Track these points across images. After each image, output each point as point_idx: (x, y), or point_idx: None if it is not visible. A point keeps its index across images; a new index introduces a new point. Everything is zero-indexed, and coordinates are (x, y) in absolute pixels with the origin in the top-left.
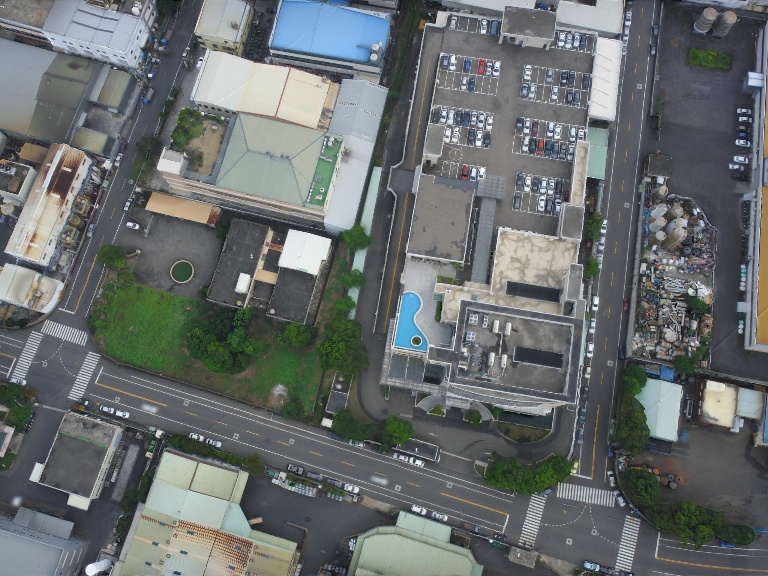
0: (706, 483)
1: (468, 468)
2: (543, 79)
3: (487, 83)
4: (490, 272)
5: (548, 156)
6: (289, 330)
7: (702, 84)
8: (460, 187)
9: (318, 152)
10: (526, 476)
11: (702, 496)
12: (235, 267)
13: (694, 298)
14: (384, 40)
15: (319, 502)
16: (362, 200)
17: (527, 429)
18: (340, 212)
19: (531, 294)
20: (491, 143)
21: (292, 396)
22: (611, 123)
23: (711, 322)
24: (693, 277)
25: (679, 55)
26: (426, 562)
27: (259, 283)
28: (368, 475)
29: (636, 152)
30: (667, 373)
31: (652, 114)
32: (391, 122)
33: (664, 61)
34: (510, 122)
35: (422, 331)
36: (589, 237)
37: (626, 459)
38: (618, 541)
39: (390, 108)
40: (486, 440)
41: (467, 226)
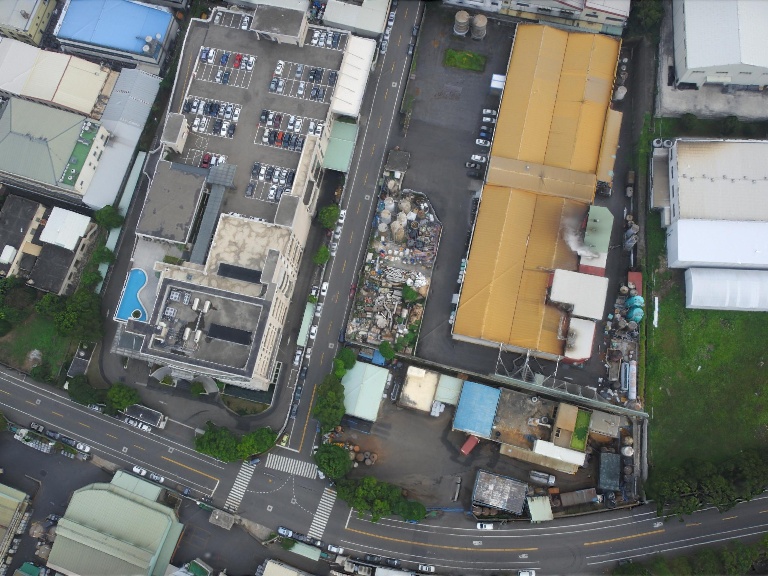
0: (402, 462)
1: (190, 435)
2: (293, 74)
3: (241, 76)
4: (207, 254)
5: (286, 148)
6: (44, 299)
7: (455, 84)
8: (193, 173)
9: (77, 136)
10: (228, 445)
11: (396, 474)
12: (5, 239)
13: (406, 288)
14: (163, 32)
15: (55, 458)
16: (125, 182)
17: (248, 403)
18: (100, 192)
19: (240, 276)
20: (235, 133)
21: (44, 360)
22: (362, 119)
23: (420, 311)
24: (416, 268)
25: (437, 55)
26: (127, 517)
27: (26, 255)
28: (100, 436)
29: (382, 147)
30: (379, 357)
31: (401, 111)
32: (165, 110)
33: (422, 61)
34: (256, 114)
35: (143, 305)
36: (324, 226)
37: (331, 435)
38: (314, 511)
39: (163, 97)
40: (210, 411)
41: (194, 210)
